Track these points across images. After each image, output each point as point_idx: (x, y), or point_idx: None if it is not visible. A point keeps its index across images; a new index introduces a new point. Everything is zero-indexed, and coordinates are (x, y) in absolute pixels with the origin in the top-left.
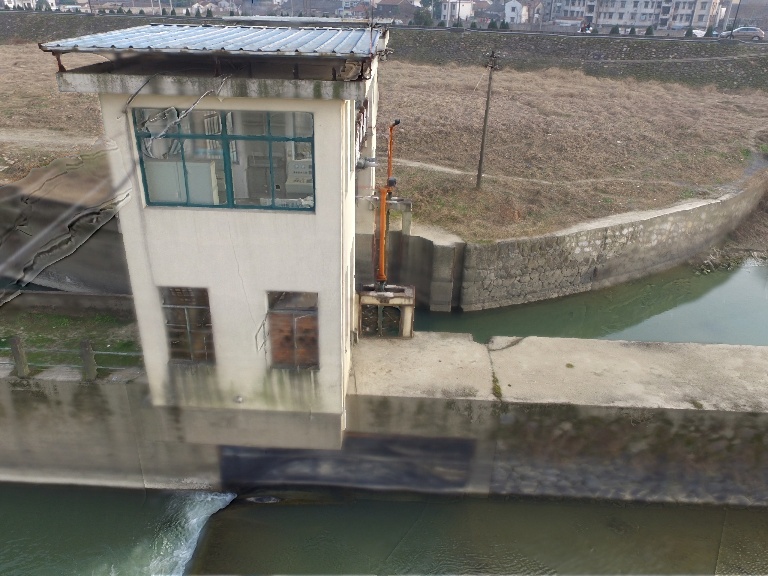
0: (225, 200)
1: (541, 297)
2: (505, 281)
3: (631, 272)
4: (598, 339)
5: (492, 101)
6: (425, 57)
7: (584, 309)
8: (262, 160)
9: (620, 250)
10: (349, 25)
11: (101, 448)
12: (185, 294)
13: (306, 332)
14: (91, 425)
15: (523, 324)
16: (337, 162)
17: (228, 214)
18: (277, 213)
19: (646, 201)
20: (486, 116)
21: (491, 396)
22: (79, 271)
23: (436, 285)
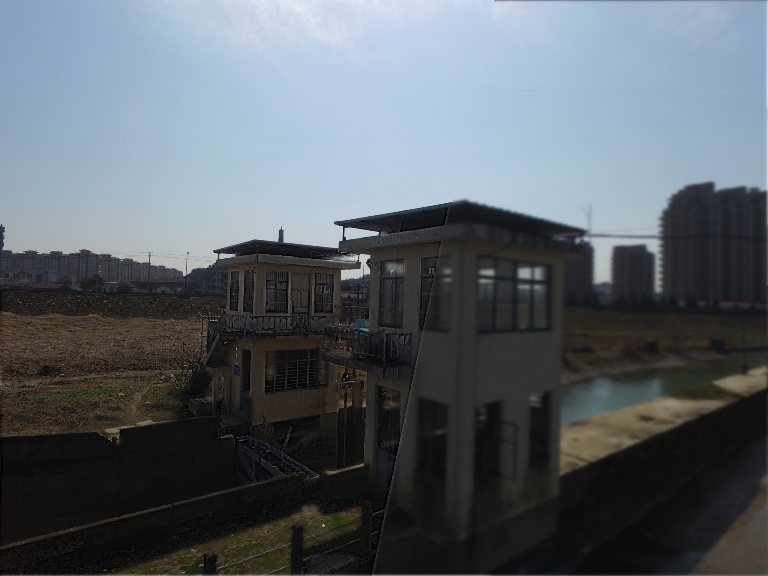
0: None
1: None
2: None
3: None
4: None
5: None
6: (165, 314)
7: None
8: None
9: None
10: (328, 254)
11: None
12: None
13: None
14: None
15: None
16: None
17: None
18: None
19: None
20: None
21: None
22: (8, 532)
23: None
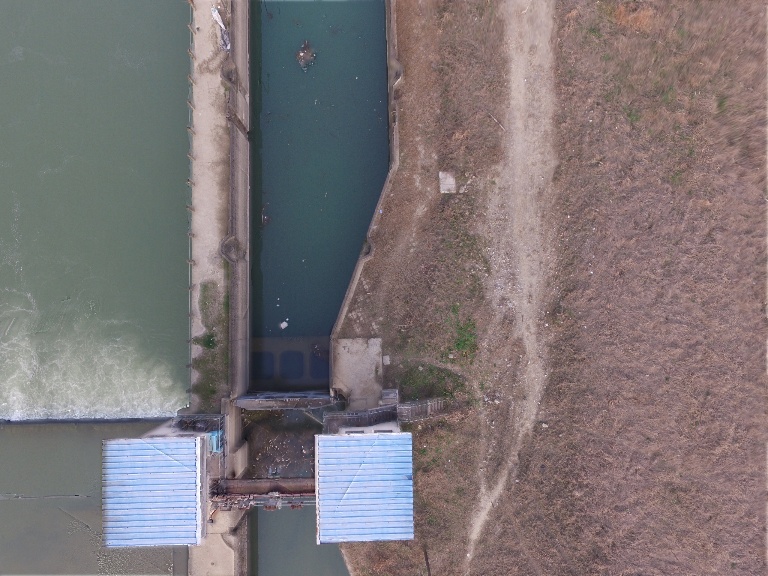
0: None
1: None
2: None
3: None
4: None
5: None
6: None
7: None
8: None
9: None
10: None
11: None
12: None
13: None
14: None
15: None
16: None
17: None
18: None
19: None
20: None
21: None
22: None
23: None
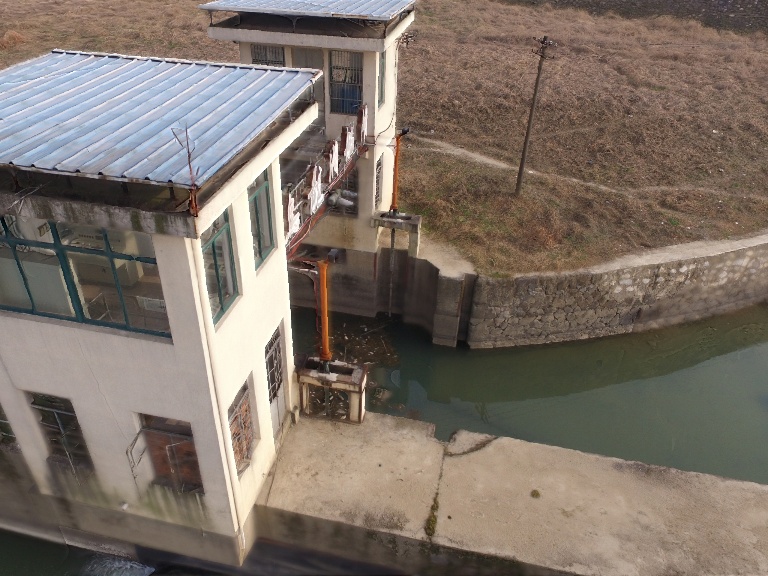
0: (92, 298)
1: (567, 338)
2: (522, 320)
3: (687, 313)
4: (586, 453)
5: (575, 63)
6: None
7: (621, 352)
8: None
9: (675, 289)
10: None
11: (18, 504)
12: (50, 399)
13: (188, 454)
14: (4, 483)
15: (543, 364)
16: (189, 293)
17: (75, 331)
18: (130, 337)
19: (723, 225)
20: (531, 113)
21: (421, 532)
22: None
23: (440, 318)
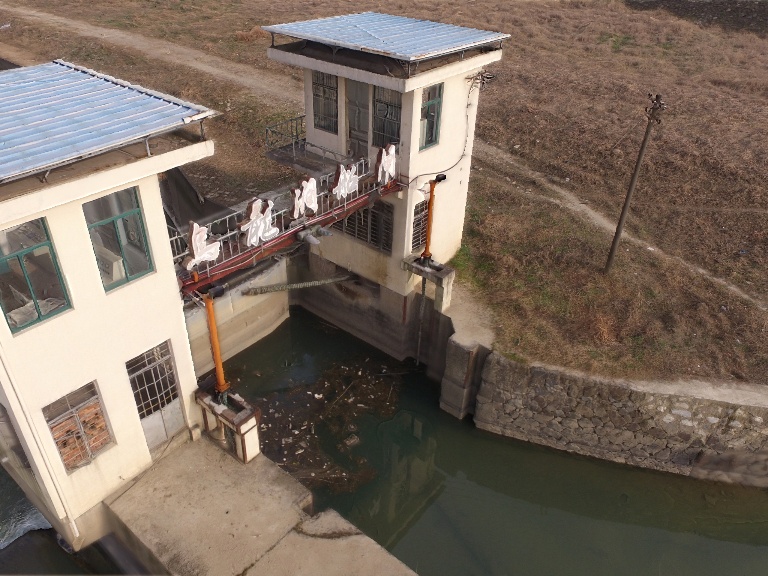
0: None
1: (596, 453)
2: (537, 415)
3: None
4: None
5: None
6: None
7: None
8: (102, 227)
9: (759, 443)
10: None
11: None
12: None
13: None
14: None
15: (563, 473)
16: None
17: None
18: None
19: None
20: (632, 182)
21: None
22: None
23: (447, 383)
